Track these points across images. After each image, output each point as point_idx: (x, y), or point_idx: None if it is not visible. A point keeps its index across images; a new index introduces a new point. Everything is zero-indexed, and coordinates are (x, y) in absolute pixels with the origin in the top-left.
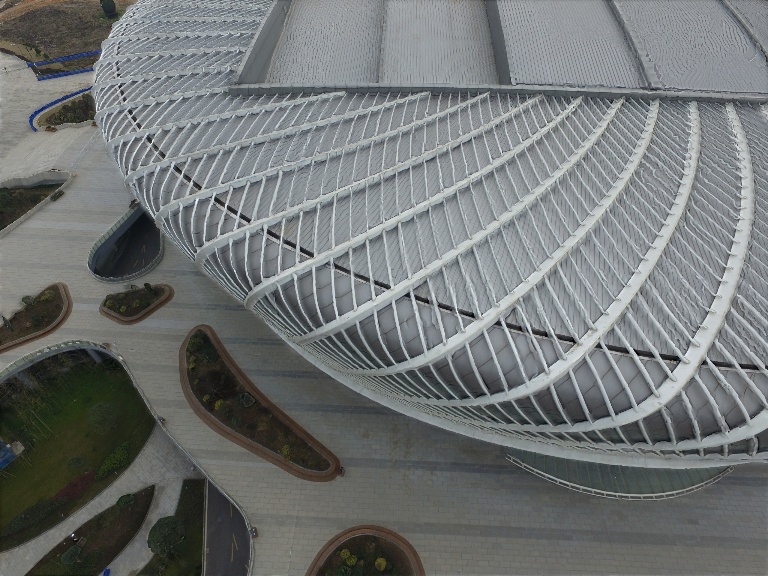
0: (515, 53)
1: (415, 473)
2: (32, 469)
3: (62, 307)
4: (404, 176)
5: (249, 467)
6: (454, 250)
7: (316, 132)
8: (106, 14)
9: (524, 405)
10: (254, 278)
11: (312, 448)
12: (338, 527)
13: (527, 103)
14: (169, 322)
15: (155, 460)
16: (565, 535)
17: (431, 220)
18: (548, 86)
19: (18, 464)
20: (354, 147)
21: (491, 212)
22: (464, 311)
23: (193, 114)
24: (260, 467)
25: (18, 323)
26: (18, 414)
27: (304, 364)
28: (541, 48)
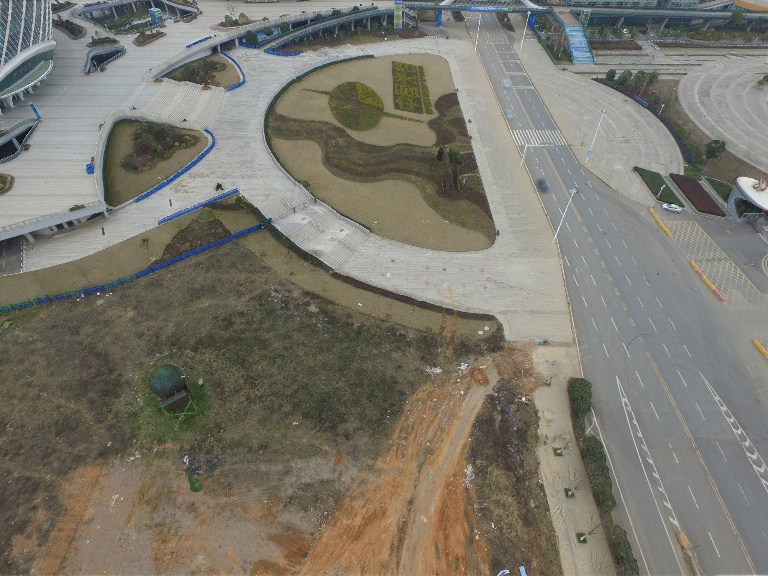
0: None
1: None
2: None
3: None
4: None
5: None
6: None
7: None
8: None
9: None
10: None
11: None
12: None
13: None
14: None
15: None
16: None
17: None
18: None
19: None
20: None
21: None
22: None
23: None
24: None
25: None
26: None
27: None
28: None
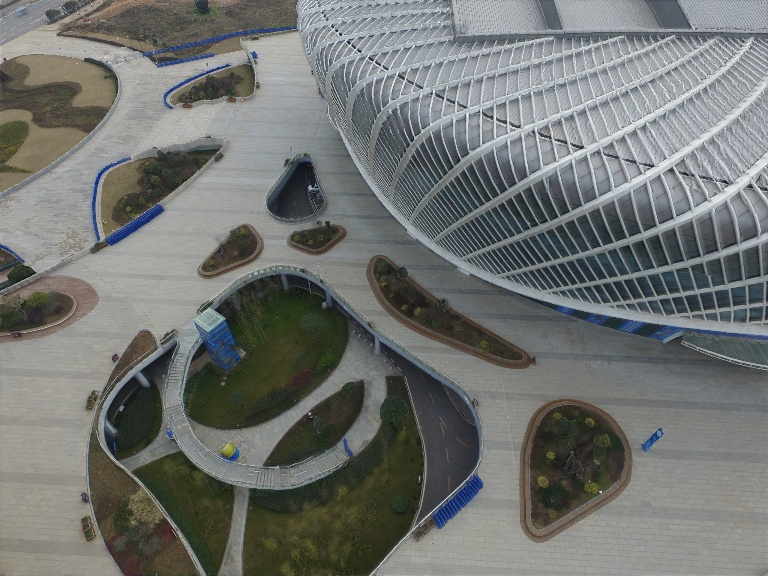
0: (686, 6)
1: (595, 363)
2: (259, 367)
3: (257, 241)
4: (636, 92)
5: (454, 358)
6: (698, 139)
7: (547, 65)
8: (200, 10)
9: (766, 250)
10: (530, 168)
11: (504, 344)
12: (542, 400)
13: (710, 42)
14: (350, 253)
15: (357, 362)
16: (734, 407)
17: (669, 121)
18: (723, 29)
19: (245, 364)
20: (584, 74)
21: (715, 115)
22: (718, 179)
23: (431, 57)
24: (463, 358)
25: (226, 253)
26: (238, 325)
27: (476, 284)
28: (706, 2)
